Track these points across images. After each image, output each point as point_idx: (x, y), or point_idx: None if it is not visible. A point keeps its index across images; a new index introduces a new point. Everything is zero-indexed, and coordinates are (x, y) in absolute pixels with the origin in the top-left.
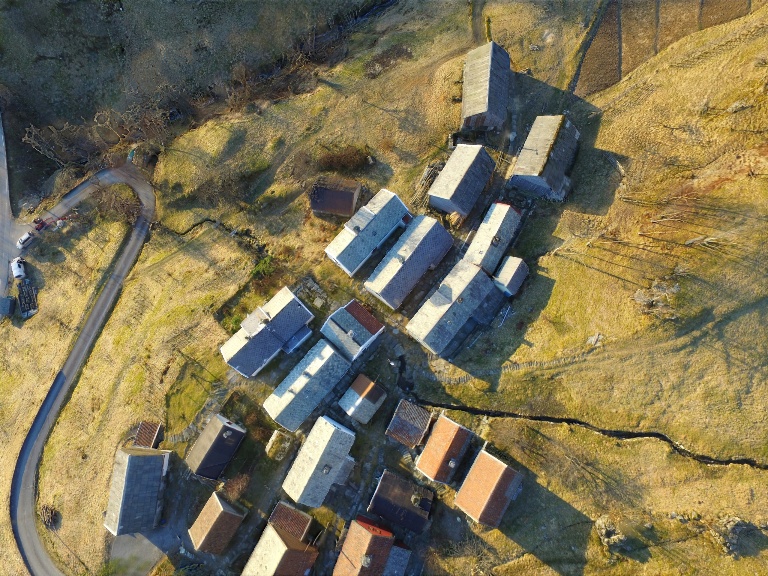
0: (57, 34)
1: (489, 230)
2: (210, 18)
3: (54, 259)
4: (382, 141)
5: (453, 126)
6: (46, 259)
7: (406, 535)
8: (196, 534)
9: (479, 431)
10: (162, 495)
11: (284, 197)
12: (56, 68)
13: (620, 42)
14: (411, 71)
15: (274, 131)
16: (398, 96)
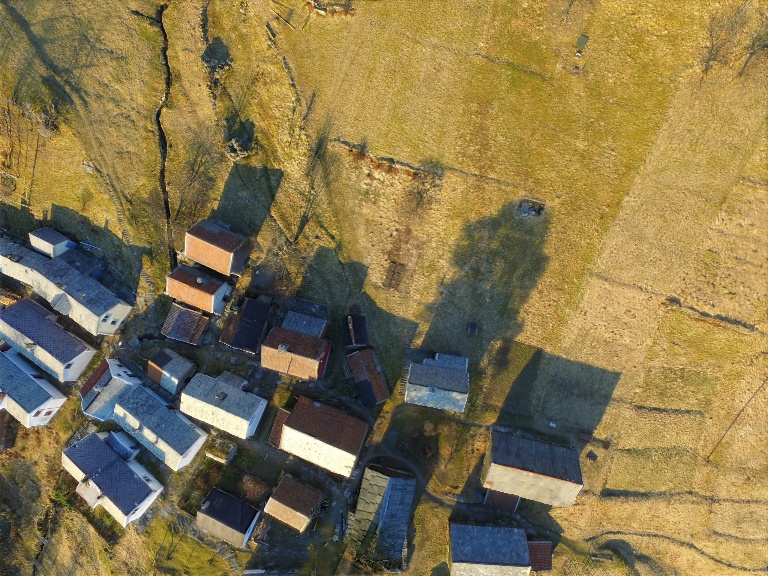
0: None
1: (6, 265)
2: None
3: None
4: None
5: None
6: None
7: (281, 317)
8: (299, 523)
9: (190, 261)
10: (286, 570)
11: None
12: None
13: None
14: None
15: None
16: None
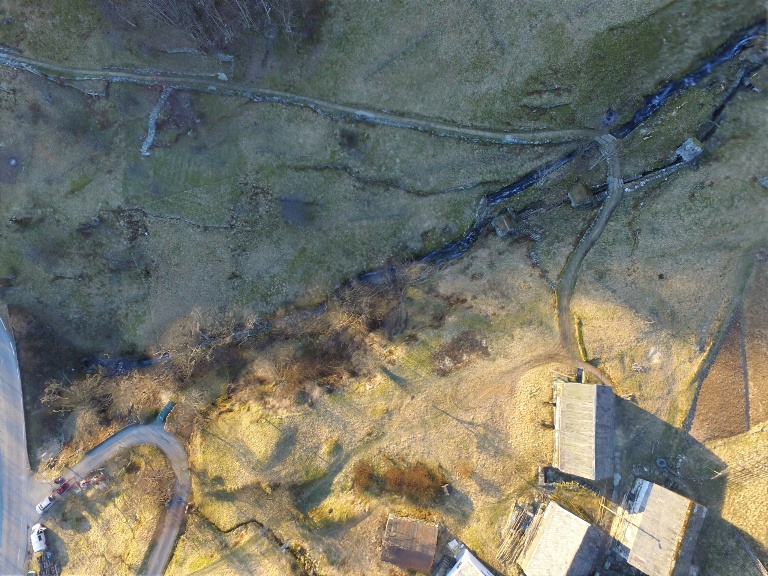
0: (76, 255)
1: None
2: (245, 246)
3: (78, 527)
4: (458, 462)
5: (544, 458)
6: (69, 525)
7: None
8: None
9: None
10: None
11: (344, 521)
12: (75, 287)
13: (746, 379)
14: (488, 375)
15: (329, 431)
16: (474, 404)
